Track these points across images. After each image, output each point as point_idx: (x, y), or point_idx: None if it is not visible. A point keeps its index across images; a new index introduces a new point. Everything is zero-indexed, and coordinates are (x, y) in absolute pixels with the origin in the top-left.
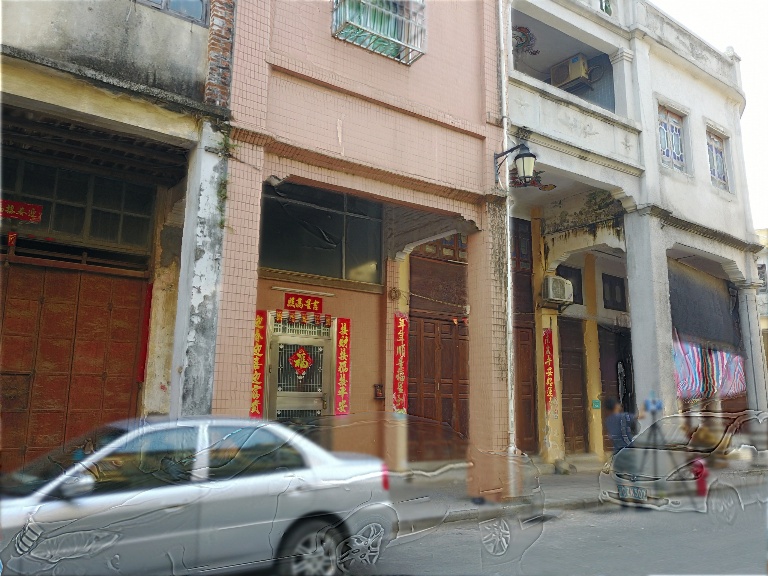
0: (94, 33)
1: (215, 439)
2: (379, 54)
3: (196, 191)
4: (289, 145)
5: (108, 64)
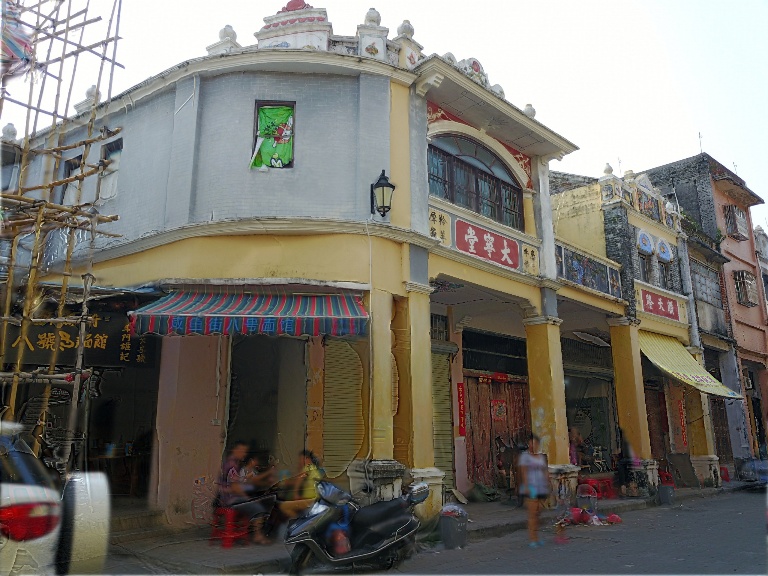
0: (714, 321)
1: (751, 451)
2: (744, 305)
3: (732, 369)
4: (743, 348)
5: (717, 330)
